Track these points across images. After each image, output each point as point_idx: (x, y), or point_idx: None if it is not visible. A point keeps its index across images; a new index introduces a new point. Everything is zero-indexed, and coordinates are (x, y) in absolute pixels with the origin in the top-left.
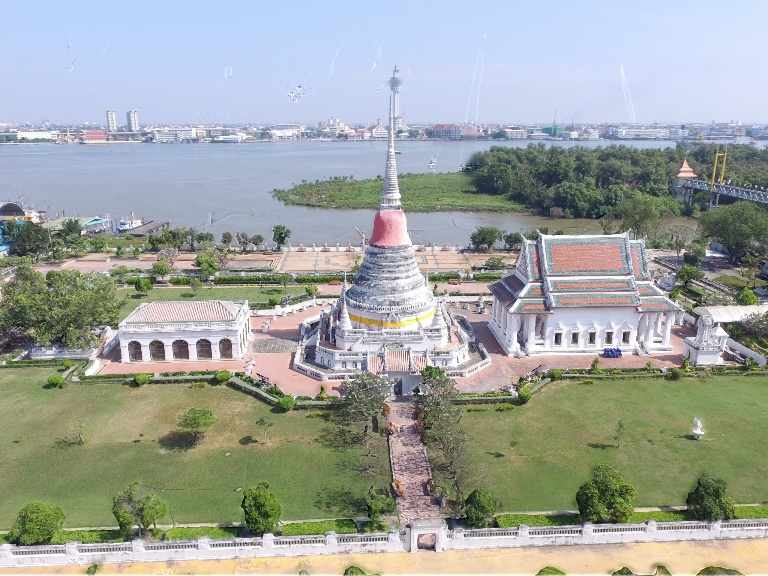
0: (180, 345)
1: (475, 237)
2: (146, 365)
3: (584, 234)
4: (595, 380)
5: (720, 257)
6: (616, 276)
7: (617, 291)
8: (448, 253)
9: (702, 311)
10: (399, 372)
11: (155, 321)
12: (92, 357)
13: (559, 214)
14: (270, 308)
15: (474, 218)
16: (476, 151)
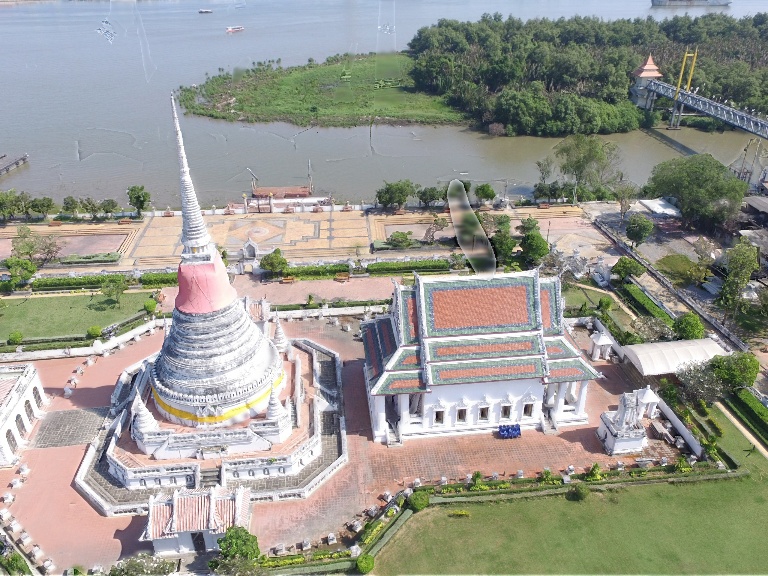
0: None
1: (380, 197)
2: None
3: (519, 175)
4: (473, 505)
5: (672, 216)
6: (518, 333)
7: (517, 356)
8: (349, 215)
9: (631, 354)
10: (193, 531)
11: None
12: None
13: (499, 132)
14: (87, 345)
15: (403, 134)
16: (395, 63)
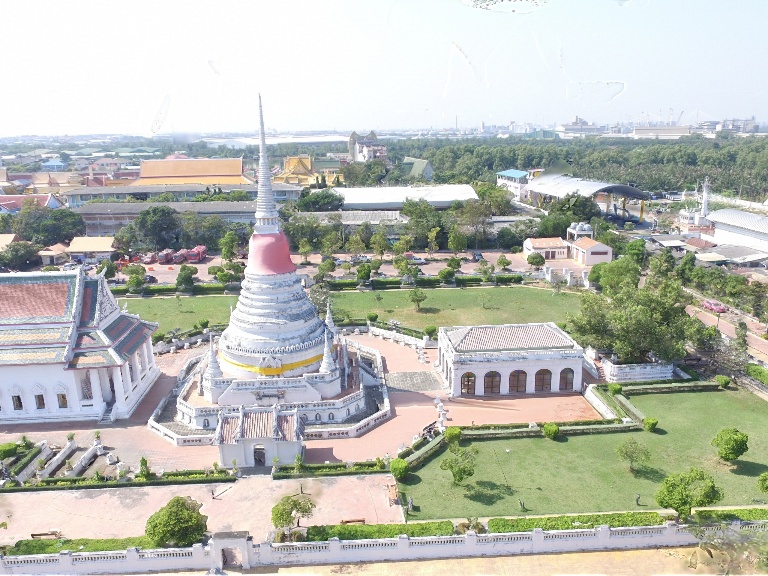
0: None
1: None
2: None
3: None
4: None
5: None
6: None
7: None
8: None
9: None
10: None
11: None
12: None
13: None
14: None
15: None
16: None
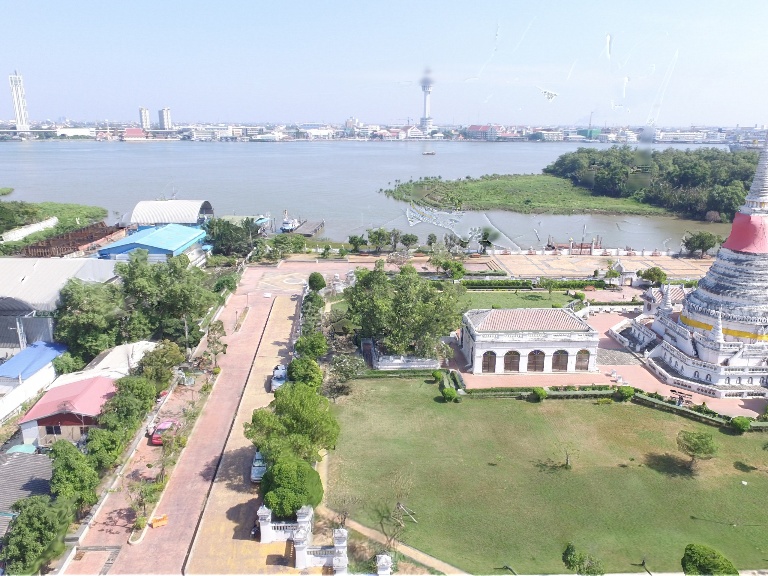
0: (536, 356)
1: (694, 242)
2: (503, 377)
3: None
4: None
5: None
6: None
7: None
8: (662, 258)
9: None
10: None
11: (504, 330)
12: (438, 367)
13: (716, 218)
14: None
15: (618, 221)
16: (650, 152)
